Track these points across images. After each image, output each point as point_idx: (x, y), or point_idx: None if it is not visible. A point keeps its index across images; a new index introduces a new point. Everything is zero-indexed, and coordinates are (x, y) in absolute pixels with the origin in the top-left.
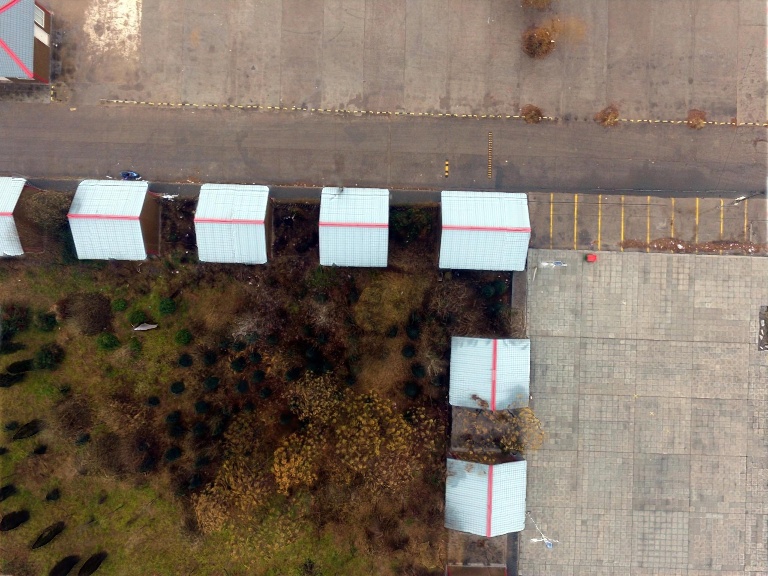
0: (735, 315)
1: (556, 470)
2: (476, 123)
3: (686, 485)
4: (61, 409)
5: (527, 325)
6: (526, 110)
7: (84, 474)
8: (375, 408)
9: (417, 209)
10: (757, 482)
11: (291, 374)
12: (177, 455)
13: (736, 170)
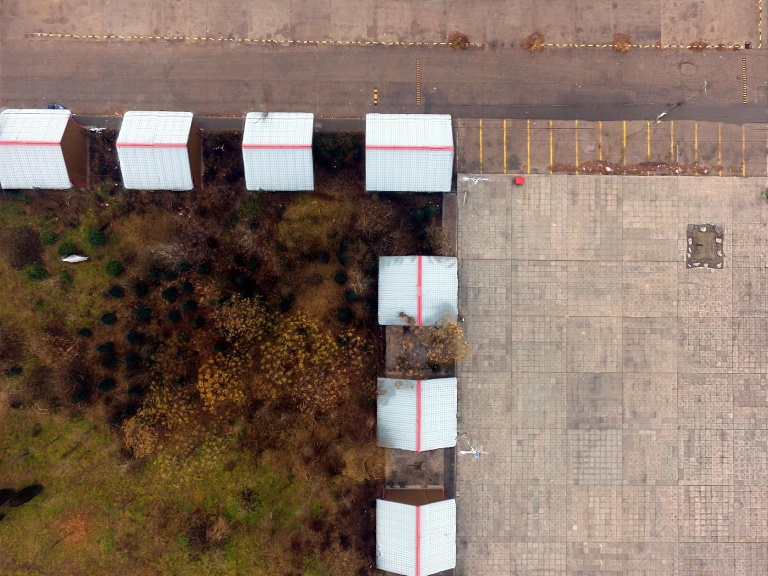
0: (663, 234)
1: (491, 392)
2: (404, 51)
3: (619, 403)
4: None
5: (458, 249)
6: (453, 37)
7: (17, 408)
8: (301, 326)
9: (343, 133)
10: (688, 398)
11: (222, 301)
12: (111, 386)
13: (662, 92)
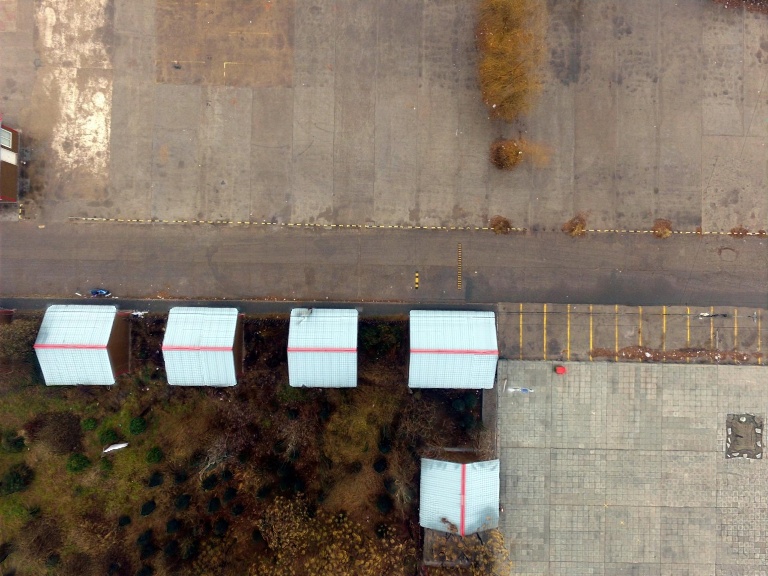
0: (702, 423)
1: None
2: (445, 235)
3: None
4: (30, 531)
5: (498, 437)
6: (495, 221)
7: None
8: (344, 536)
9: (386, 328)
10: None
11: (262, 493)
12: (148, 575)
13: (702, 278)
